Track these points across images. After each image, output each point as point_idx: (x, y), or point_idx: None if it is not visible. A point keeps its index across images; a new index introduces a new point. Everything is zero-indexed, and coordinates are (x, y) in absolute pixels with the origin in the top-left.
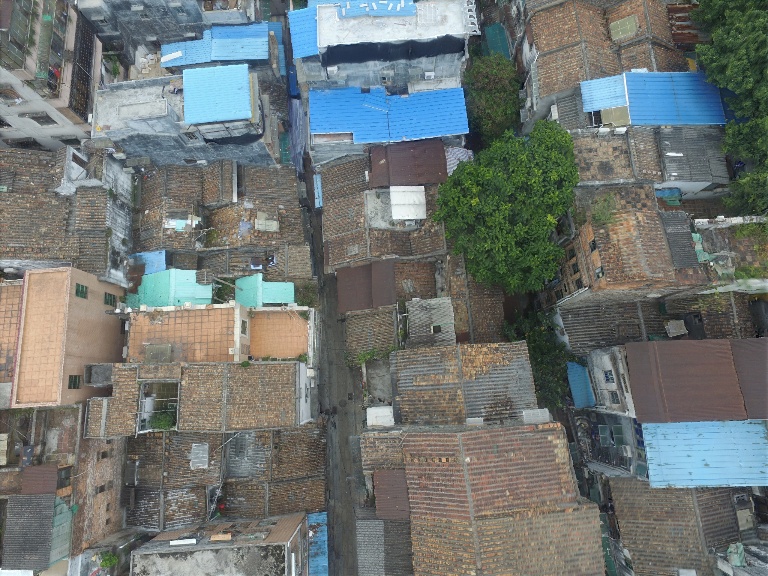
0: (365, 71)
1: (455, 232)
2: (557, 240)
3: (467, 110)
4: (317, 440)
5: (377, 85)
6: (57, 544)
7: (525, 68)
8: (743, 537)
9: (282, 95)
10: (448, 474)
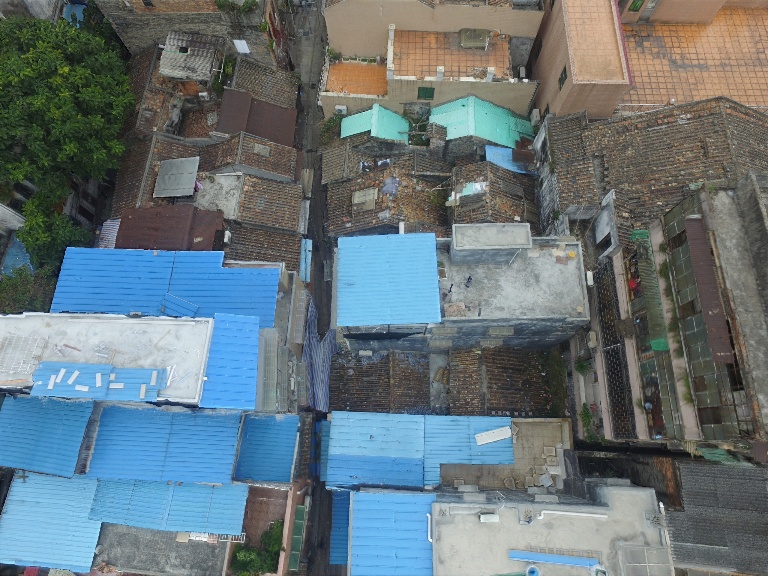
0: None
1: None
2: None
3: None
4: None
5: None
6: None
7: None
8: None
9: (335, 396)
10: None
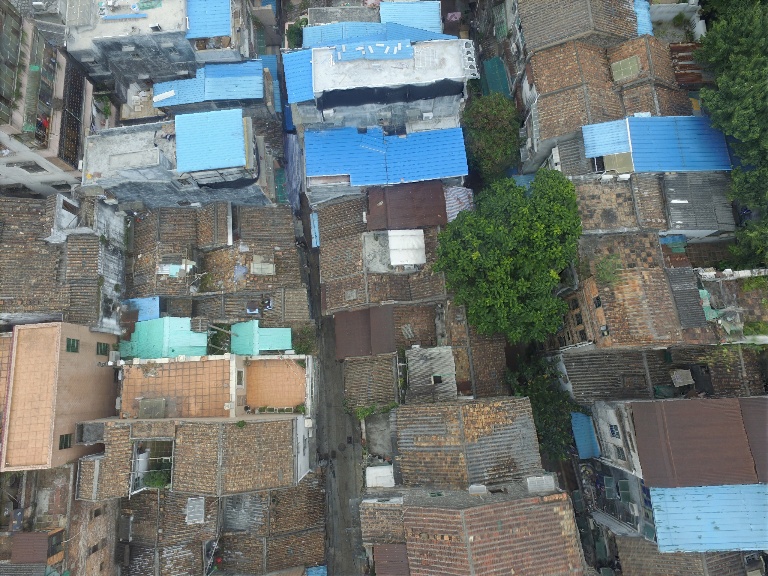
0: (362, 113)
1: (455, 283)
2: (560, 288)
3: (466, 149)
4: (316, 491)
5: (374, 125)
6: None
7: (525, 106)
8: None
9: (277, 132)
10: (451, 553)
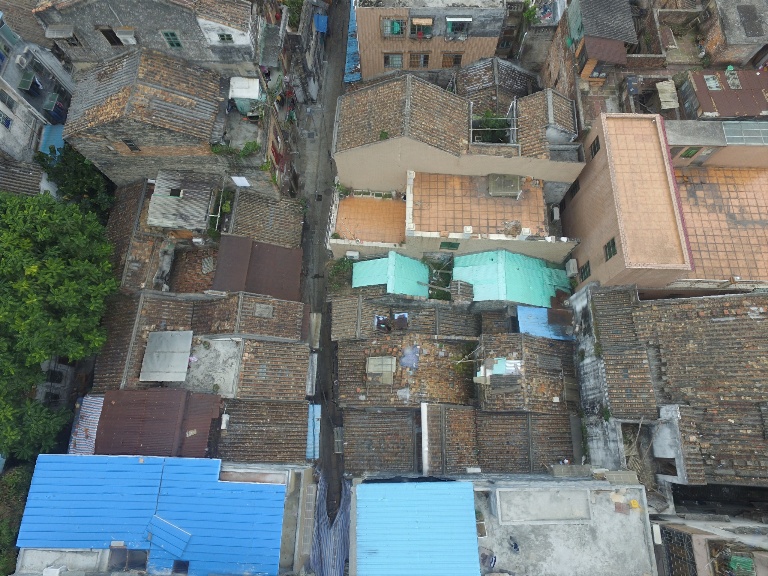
0: None
1: None
2: None
3: None
4: None
5: (158, 575)
6: (576, 7)
7: None
8: None
9: None
10: None
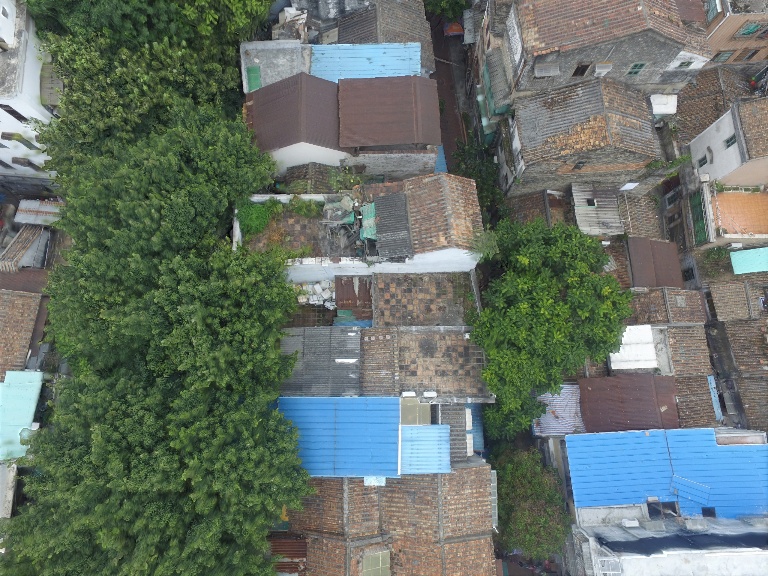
0: (730, 529)
1: None
2: None
3: (559, 480)
4: None
5: None
6: None
7: None
8: (334, 26)
9: None
10: (652, 3)
